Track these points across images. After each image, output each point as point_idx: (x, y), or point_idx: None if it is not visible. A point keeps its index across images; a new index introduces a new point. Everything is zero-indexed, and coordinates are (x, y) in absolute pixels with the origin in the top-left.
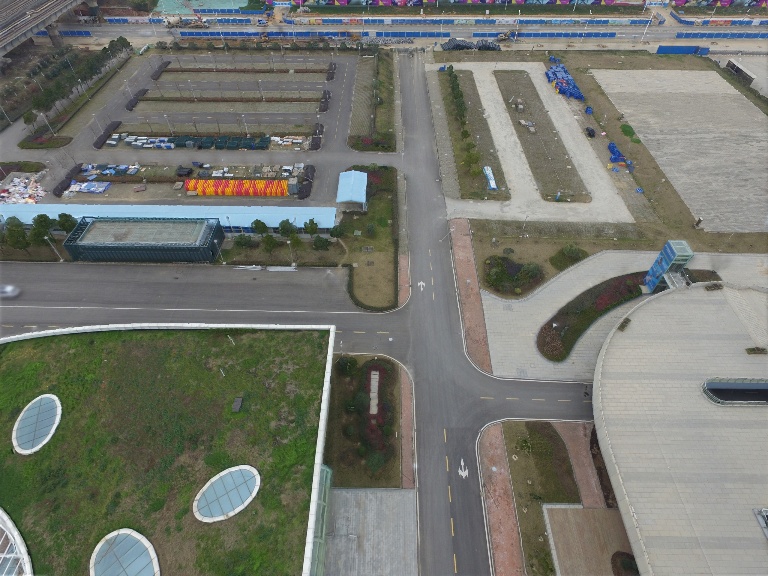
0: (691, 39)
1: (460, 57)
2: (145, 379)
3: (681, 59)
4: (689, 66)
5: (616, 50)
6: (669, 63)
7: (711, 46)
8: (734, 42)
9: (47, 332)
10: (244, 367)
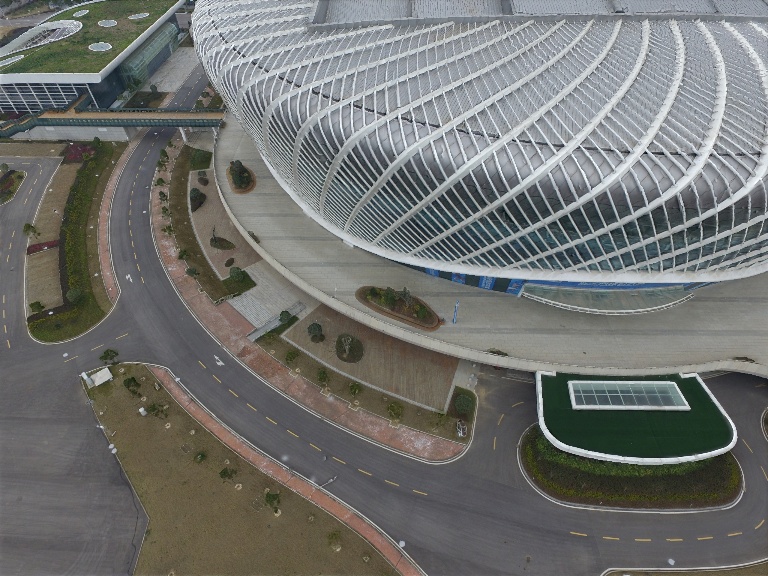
0: None
1: None
2: (117, 6)
3: None
4: None
5: None
6: None
7: None
8: None
9: (83, 3)
10: (150, 3)
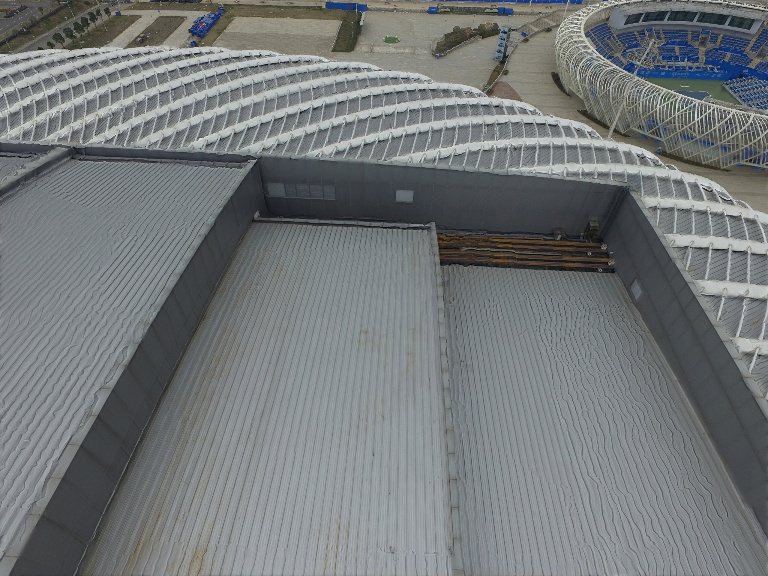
0: (374, 0)
1: (147, 6)
2: None
3: (328, 12)
4: (325, 17)
5: (295, 6)
6: (312, 14)
7: (382, 5)
8: (407, 3)
9: None
10: None
